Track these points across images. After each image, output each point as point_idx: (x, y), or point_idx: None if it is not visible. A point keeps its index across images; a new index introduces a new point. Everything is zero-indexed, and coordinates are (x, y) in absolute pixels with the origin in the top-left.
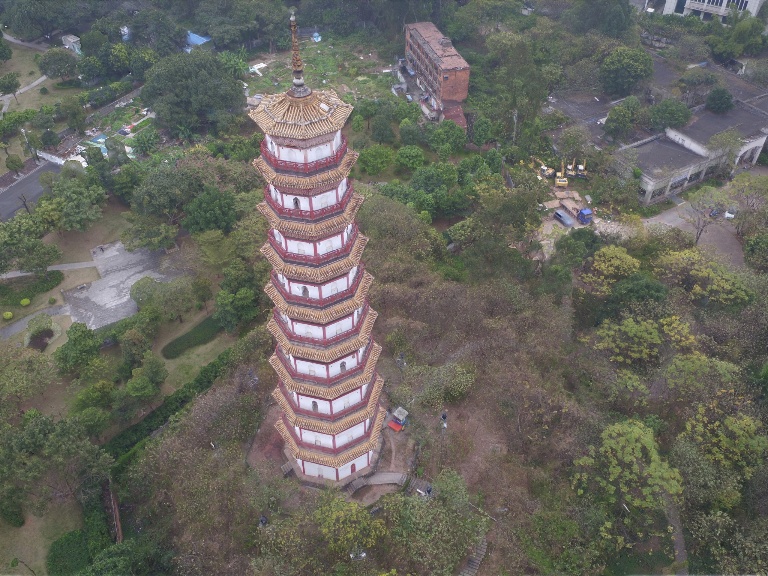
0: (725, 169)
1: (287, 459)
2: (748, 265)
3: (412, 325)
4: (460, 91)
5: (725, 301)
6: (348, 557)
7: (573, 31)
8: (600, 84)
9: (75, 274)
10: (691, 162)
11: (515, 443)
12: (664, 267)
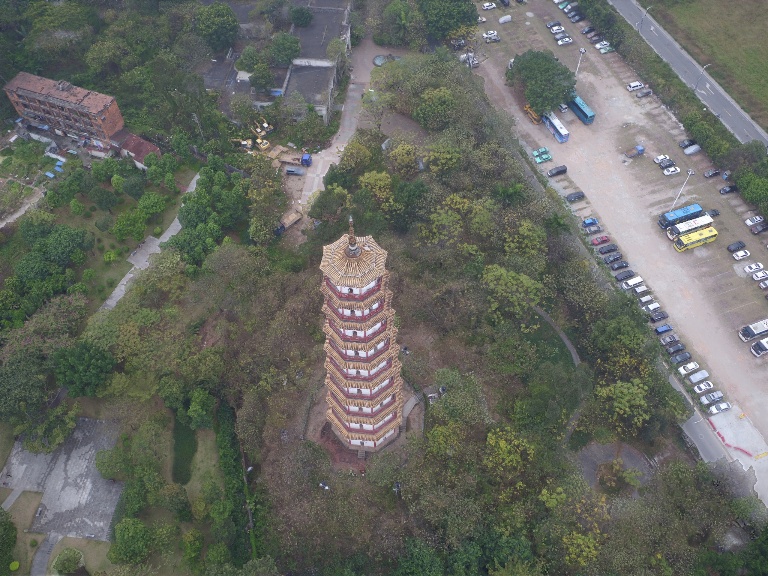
0: (343, 65)
1: (356, 450)
2: (432, 131)
3: None
4: (117, 121)
5: (453, 165)
6: (447, 456)
7: (147, 13)
8: (209, 48)
9: (16, 511)
10: (328, 76)
11: (434, 329)
12: (405, 167)
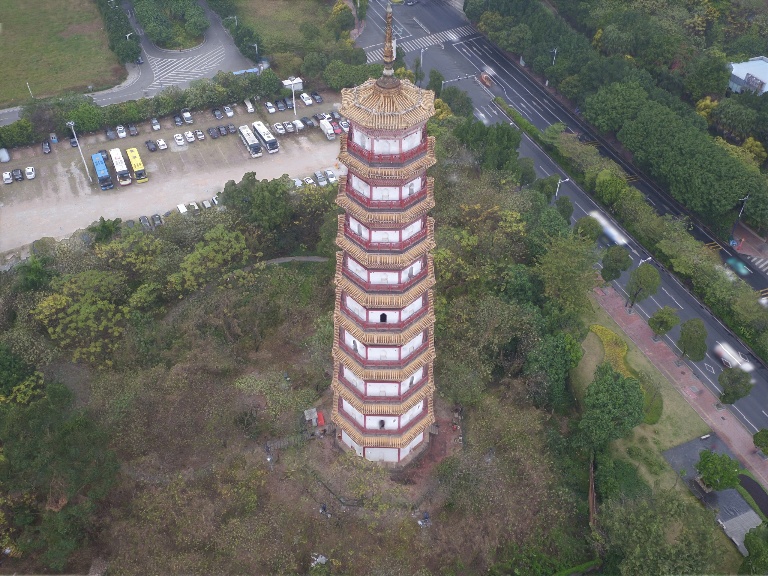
0: None
1: None
2: None
3: (238, 451)
4: None
5: None
6: None
7: None
8: None
9: None
10: None
11: None
12: None
